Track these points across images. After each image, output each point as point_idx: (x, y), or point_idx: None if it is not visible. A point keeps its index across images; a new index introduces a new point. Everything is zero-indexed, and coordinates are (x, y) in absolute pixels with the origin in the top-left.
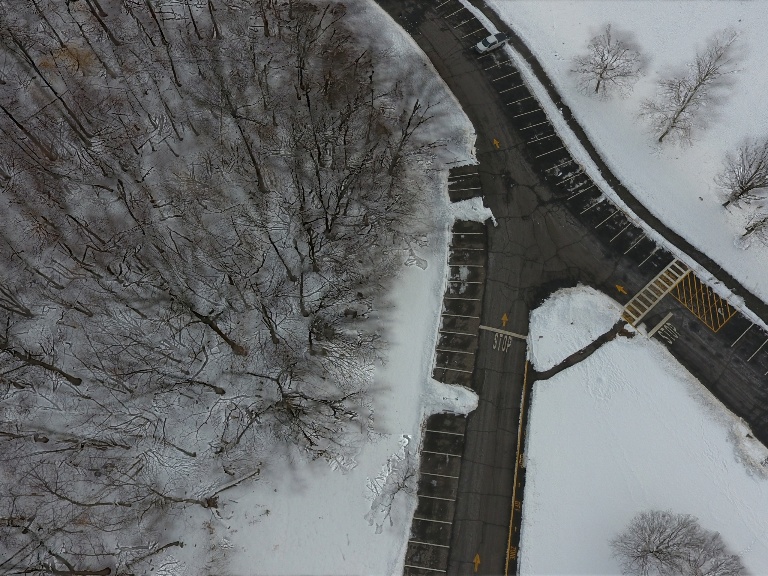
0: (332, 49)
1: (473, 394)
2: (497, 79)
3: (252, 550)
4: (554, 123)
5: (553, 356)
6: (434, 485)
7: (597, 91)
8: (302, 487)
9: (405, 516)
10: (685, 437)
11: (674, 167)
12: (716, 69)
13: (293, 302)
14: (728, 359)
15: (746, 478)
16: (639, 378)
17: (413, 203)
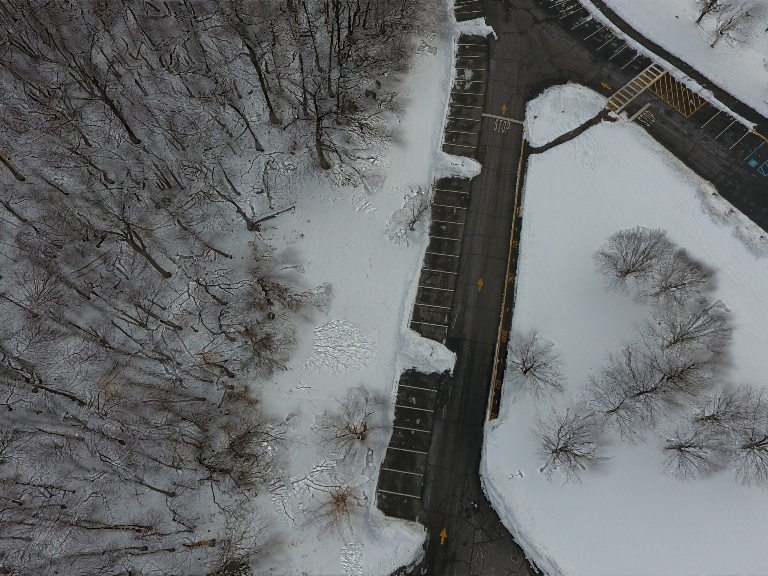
0: None
1: (477, 163)
2: None
3: (290, 263)
4: None
5: (546, 135)
6: (443, 229)
7: None
8: (331, 221)
9: (419, 250)
10: (660, 195)
11: None
12: None
13: (321, 81)
14: (698, 137)
15: (711, 224)
16: (621, 151)
17: (424, 11)
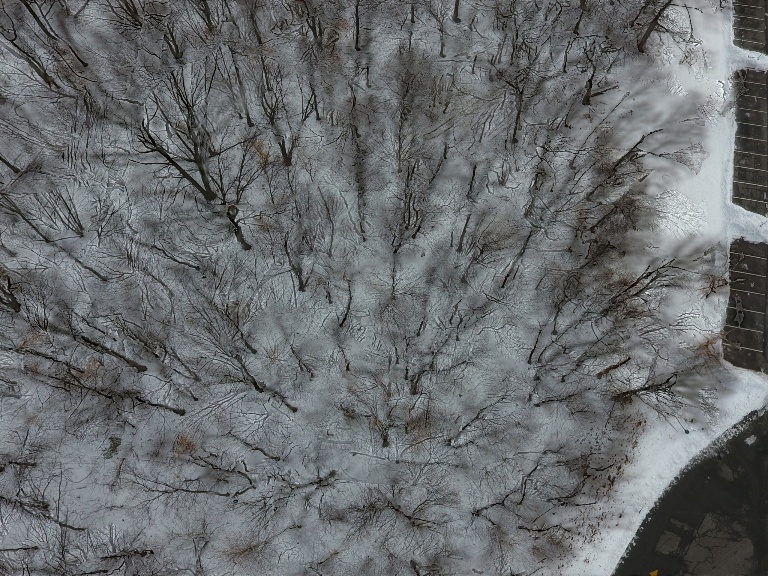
0: None
1: None
2: None
3: (624, 136)
4: None
5: None
6: (748, 116)
7: None
8: (653, 100)
9: (729, 133)
10: None
11: None
12: None
13: None
14: None
15: None
16: None
17: None
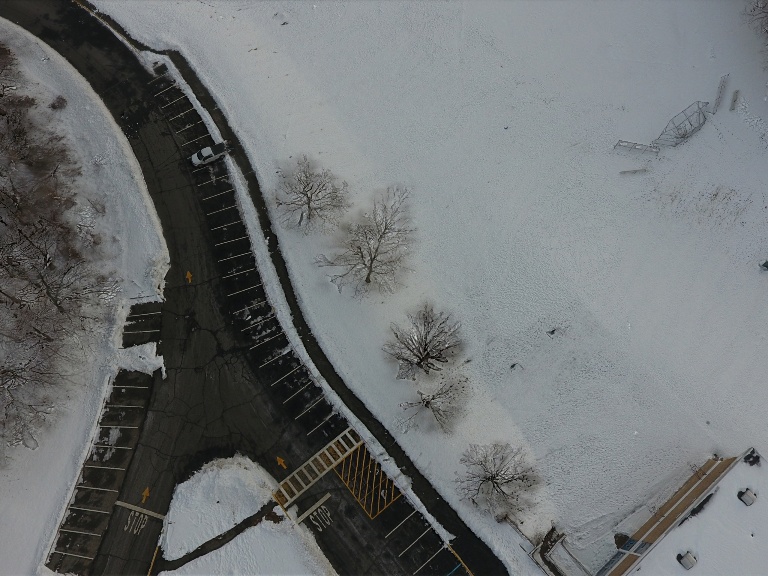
0: (40, 152)
1: None
2: (208, 198)
3: None
4: (256, 255)
5: (187, 542)
6: None
7: (300, 224)
8: None
9: None
10: None
11: (375, 314)
12: (392, 225)
13: None
14: (378, 553)
15: None
16: (274, 573)
17: (54, 360)
